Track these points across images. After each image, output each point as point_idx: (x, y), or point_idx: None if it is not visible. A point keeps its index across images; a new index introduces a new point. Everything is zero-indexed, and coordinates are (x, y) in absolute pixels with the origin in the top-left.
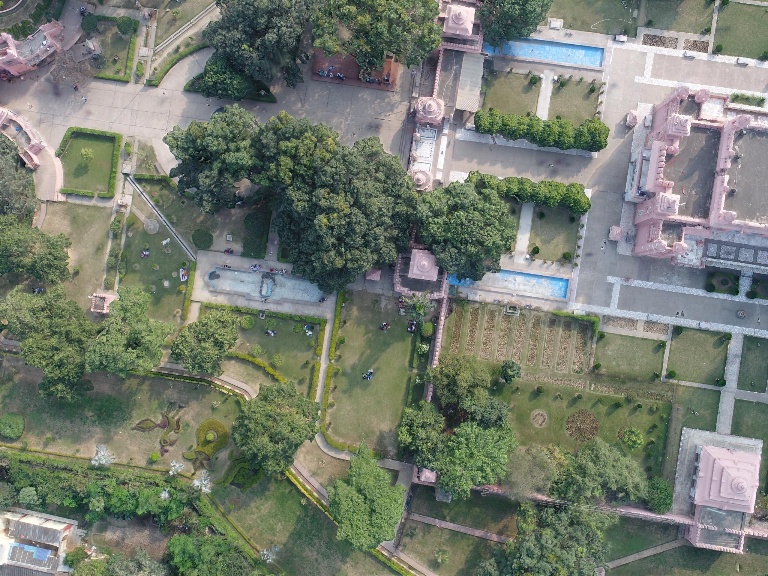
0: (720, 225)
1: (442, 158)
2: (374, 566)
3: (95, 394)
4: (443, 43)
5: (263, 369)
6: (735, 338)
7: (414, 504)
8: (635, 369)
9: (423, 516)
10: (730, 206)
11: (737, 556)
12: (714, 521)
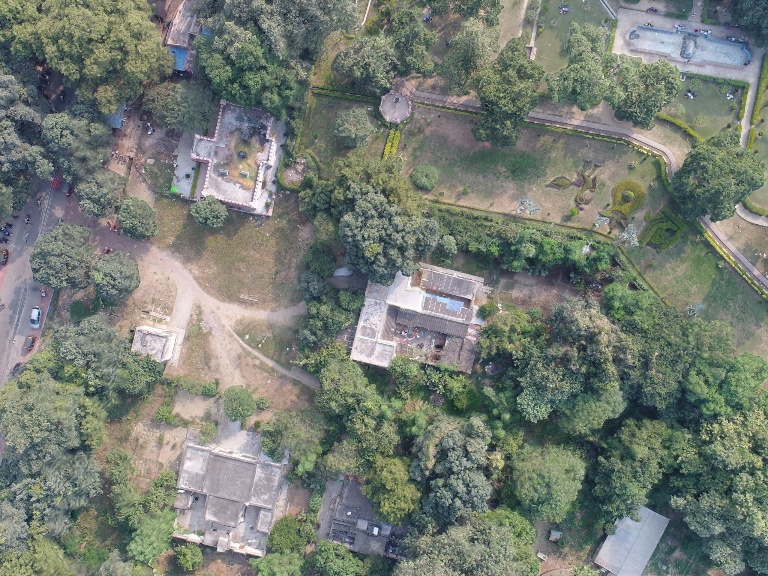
0: None
1: None
2: None
3: (508, 150)
4: None
5: (681, 131)
6: None
7: None
8: None
9: None
10: None
11: None
12: None
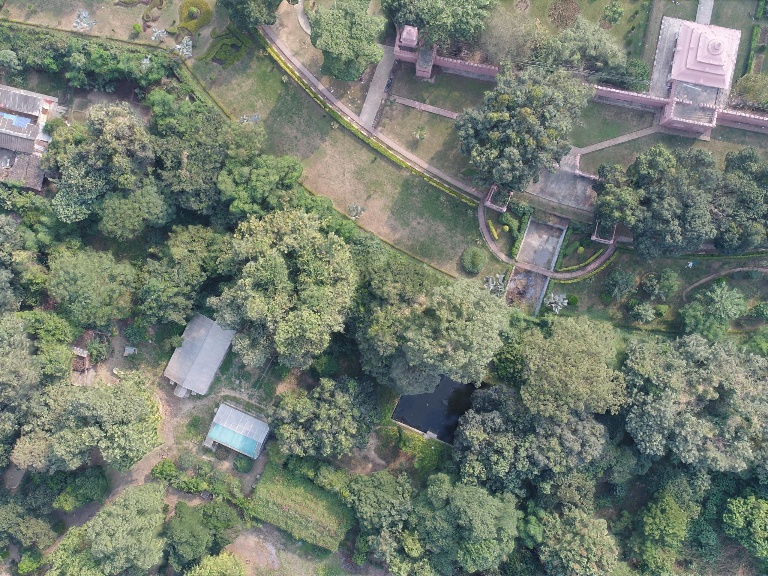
0: None
1: None
2: (353, 145)
3: None
4: None
5: None
6: None
7: (395, 87)
8: None
9: (403, 98)
10: None
11: (710, 144)
12: (689, 96)
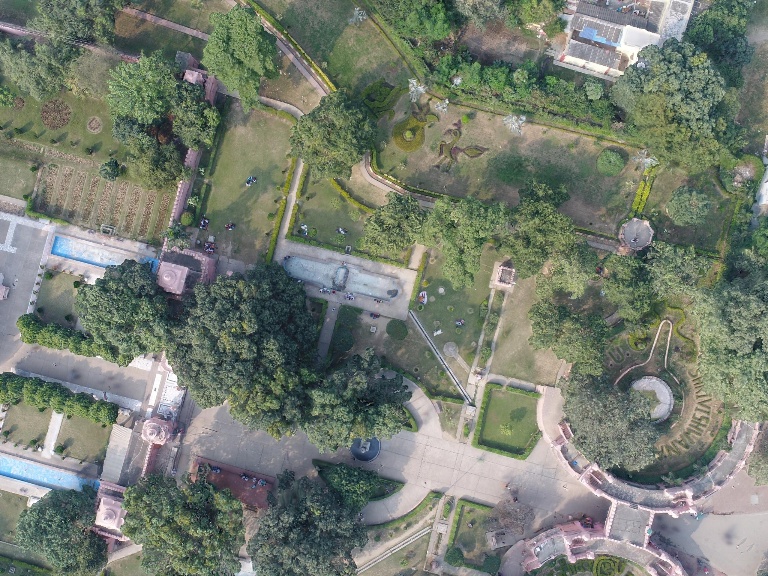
0: None
1: (157, 384)
2: None
3: (524, 187)
4: None
5: (353, 197)
6: None
7: None
8: (2, 163)
9: None
10: None
11: None
12: None
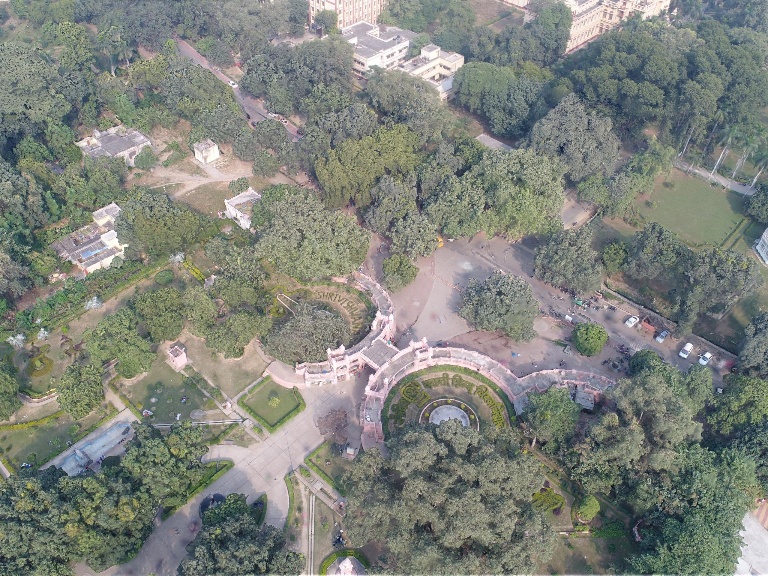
0: None
1: None
2: None
3: None
4: None
5: None
6: None
7: None
8: None
9: None
10: None
11: None
12: None
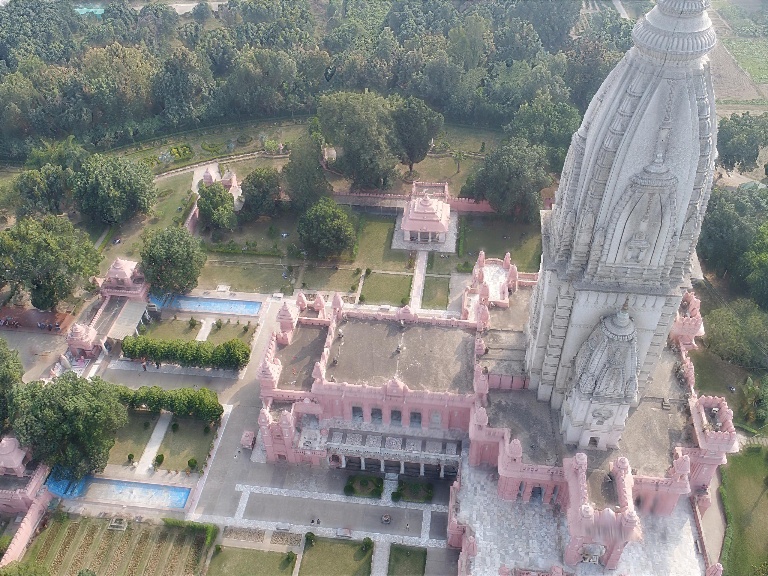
0: (320, 390)
1: None
2: None
3: None
4: (108, 290)
5: None
6: (380, 547)
7: None
8: None
9: None
10: (331, 374)
11: None
12: None
